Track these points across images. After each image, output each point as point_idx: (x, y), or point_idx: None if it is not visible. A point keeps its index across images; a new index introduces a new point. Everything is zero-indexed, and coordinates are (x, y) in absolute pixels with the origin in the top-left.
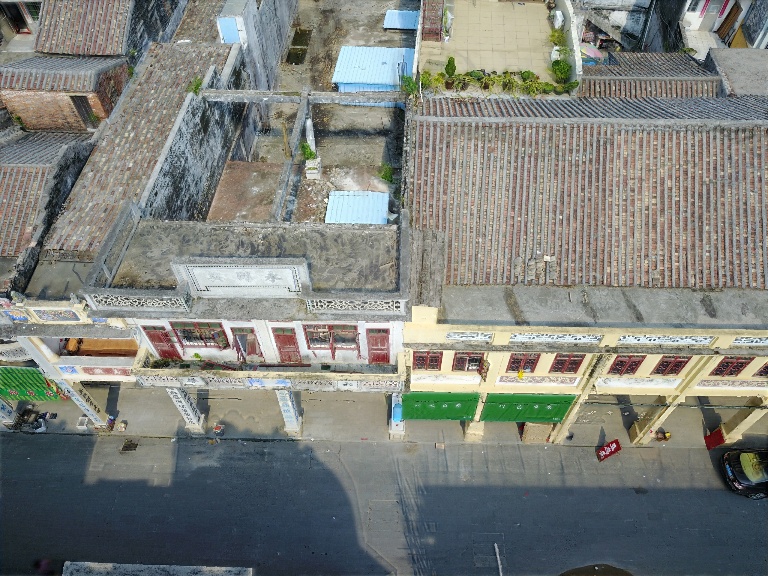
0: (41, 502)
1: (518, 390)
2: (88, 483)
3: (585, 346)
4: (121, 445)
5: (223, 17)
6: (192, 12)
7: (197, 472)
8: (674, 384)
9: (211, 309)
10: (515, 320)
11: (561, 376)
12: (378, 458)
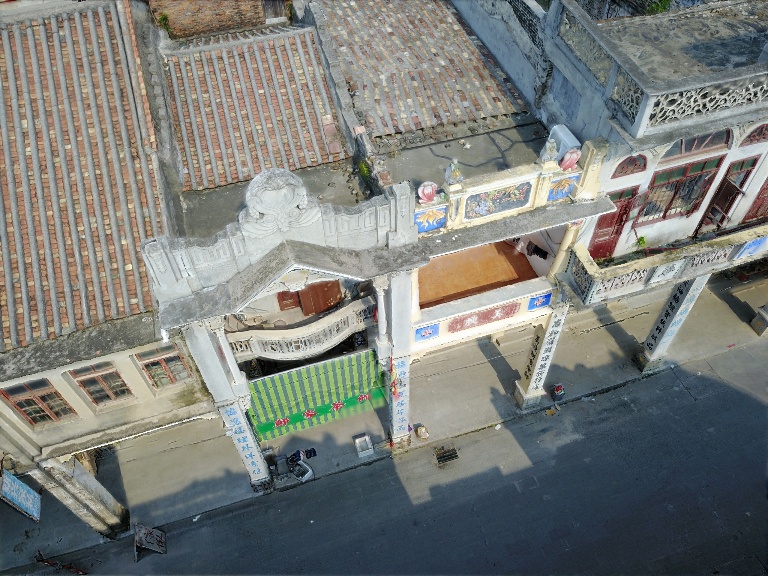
0: (376, 573)
1: None
2: (426, 522)
3: None
4: (433, 457)
5: None
6: None
7: (562, 454)
8: None
9: None
10: None
11: None
12: (762, 361)
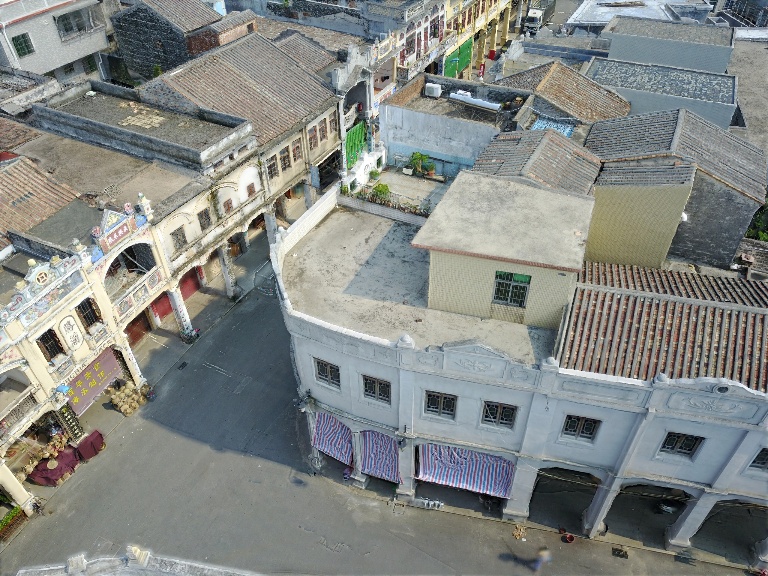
0: None
1: (464, 40)
2: None
3: (472, 2)
4: None
5: (217, 2)
6: None
7: None
8: (484, 19)
9: (425, 8)
10: None
11: (468, 28)
12: None
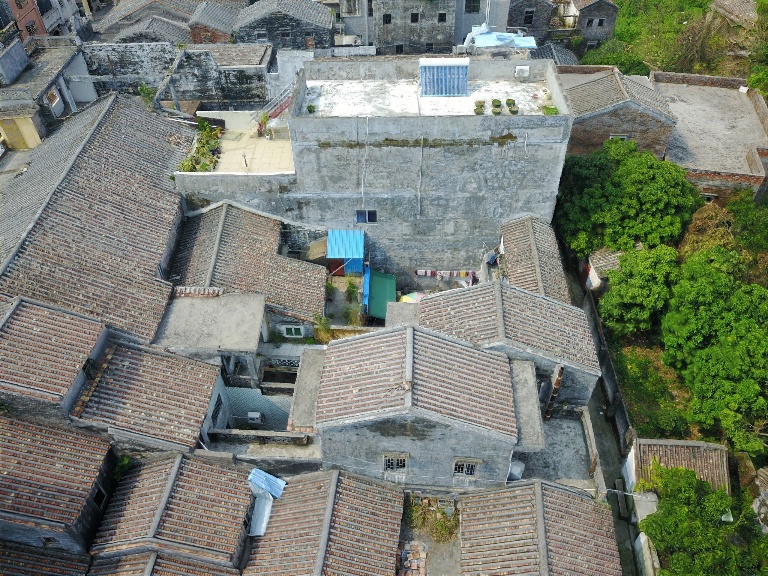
0: None
1: None
2: None
3: None
4: None
5: (277, 51)
6: (333, 58)
7: None
8: None
9: None
10: (4, 171)
11: None
12: None
